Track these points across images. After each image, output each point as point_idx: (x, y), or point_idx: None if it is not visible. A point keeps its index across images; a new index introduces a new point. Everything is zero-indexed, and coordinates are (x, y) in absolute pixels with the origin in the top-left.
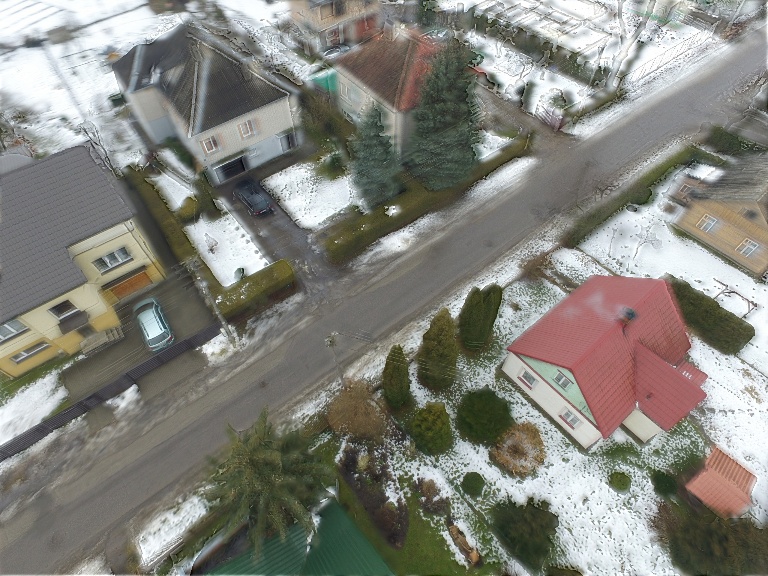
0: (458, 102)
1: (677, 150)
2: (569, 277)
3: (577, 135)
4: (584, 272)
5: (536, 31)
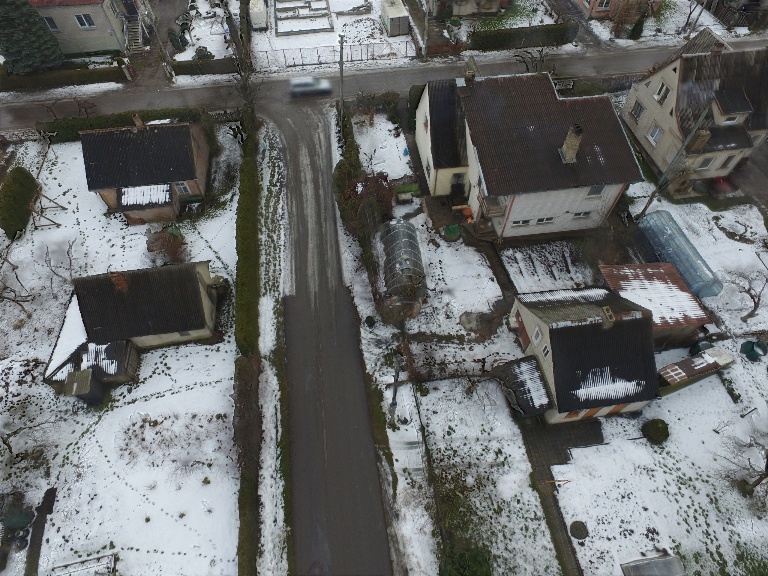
0: (4, 4)
1: (187, 110)
2: (16, 158)
3: (176, 84)
4: (28, 160)
5: (254, 3)
